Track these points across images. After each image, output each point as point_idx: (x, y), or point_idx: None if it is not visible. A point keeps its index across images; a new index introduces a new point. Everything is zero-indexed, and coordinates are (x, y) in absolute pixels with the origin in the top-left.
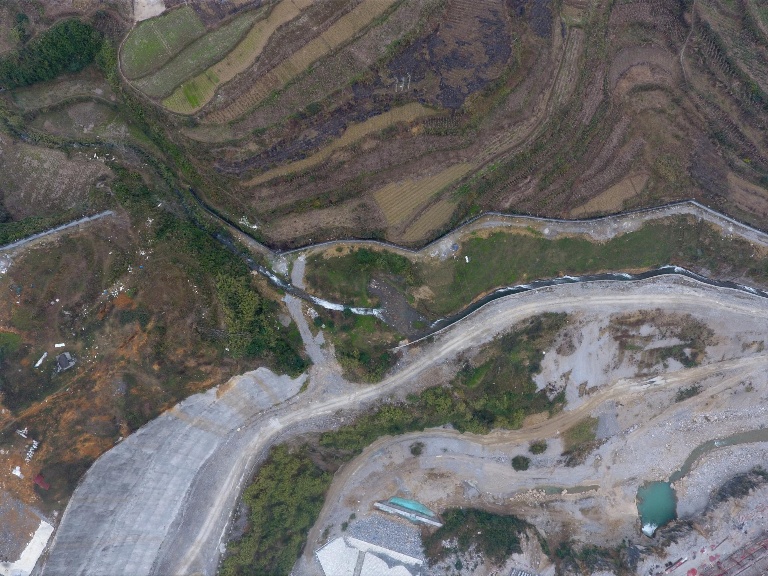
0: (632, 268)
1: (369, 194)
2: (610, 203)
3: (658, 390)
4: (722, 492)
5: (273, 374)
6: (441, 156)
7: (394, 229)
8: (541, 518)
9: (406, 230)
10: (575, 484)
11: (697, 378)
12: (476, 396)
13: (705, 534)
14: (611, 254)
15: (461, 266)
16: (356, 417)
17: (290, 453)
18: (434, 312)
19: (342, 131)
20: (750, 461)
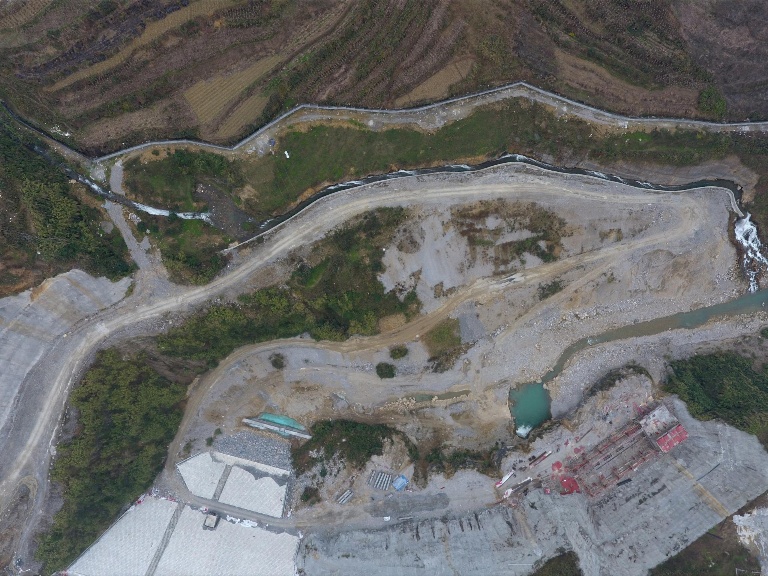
0: (467, 157)
1: (179, 94)
2: (435, 90)
3: (518, 287)
4: (593, 388)
5: (89, 276)
6: (247, 49)
7: (206, 127)
8: (411, 425)
9: (219, 127)
10: (445, 390)
11: (557, 272)
12: (314, 296)
13: (572, 428)
14: (443, 144)
15: (281, 162)
16: (184, 319)
17: (125, 360)
18: (259, 211)
19: (141, 29)
20: (624, 356)
